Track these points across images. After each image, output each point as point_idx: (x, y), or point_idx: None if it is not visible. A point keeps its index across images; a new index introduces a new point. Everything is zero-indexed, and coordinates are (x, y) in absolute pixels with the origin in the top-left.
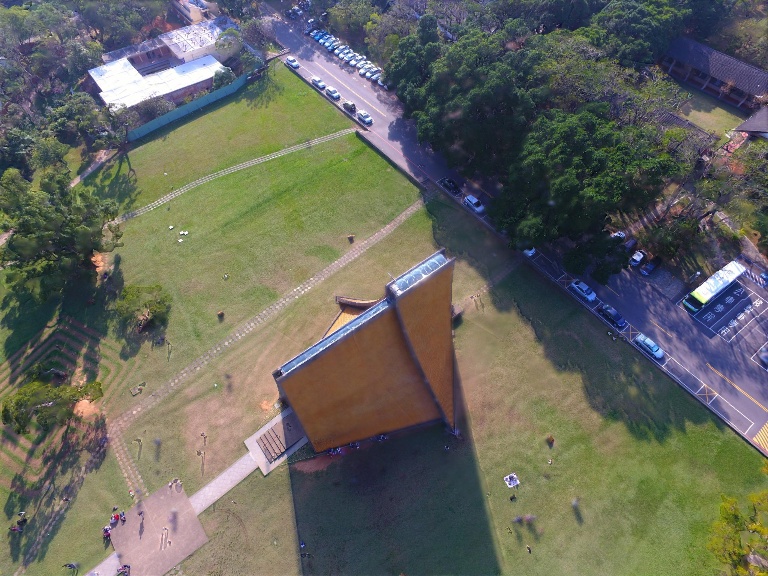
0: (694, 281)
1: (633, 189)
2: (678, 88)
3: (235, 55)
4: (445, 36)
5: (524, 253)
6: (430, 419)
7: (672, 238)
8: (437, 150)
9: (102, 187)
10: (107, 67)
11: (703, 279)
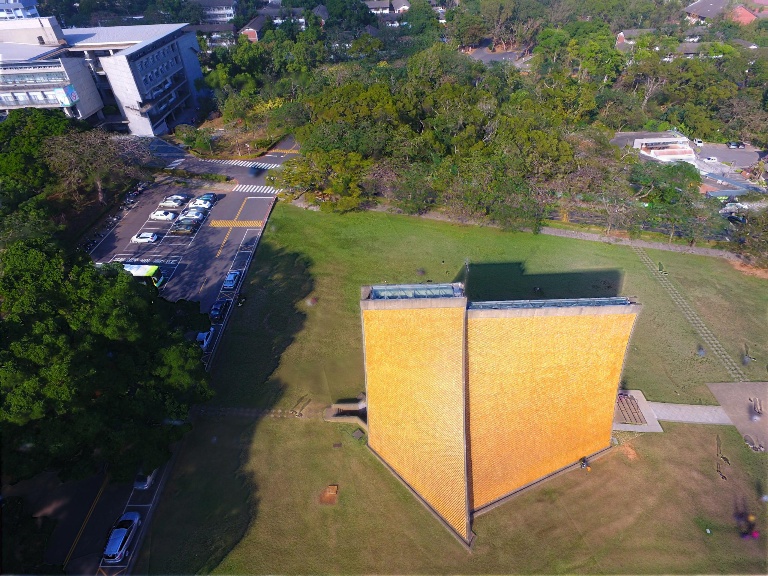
0: None
1: None
2: None
3: None
4: None
5: None
6: None
7: None
8: None
9: None
10: None
11: None
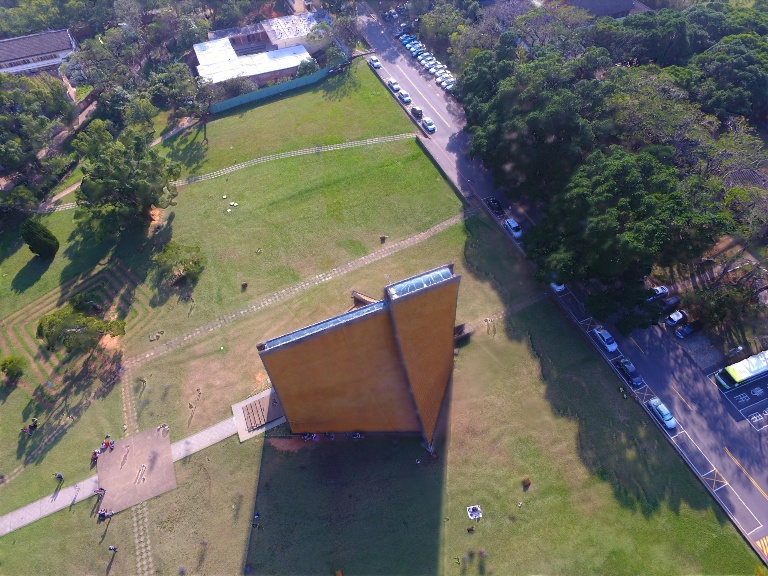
0: (735, 356)
1: (677, 242)
2: (762, 144)
3: (324, 48)
4: (529, 56)
5: (552, 287)
6: (409, 430)
7: (716, 304)
8: (488, 168)
9: (177, 150)
10: (210, 44)
11: (747, 356)
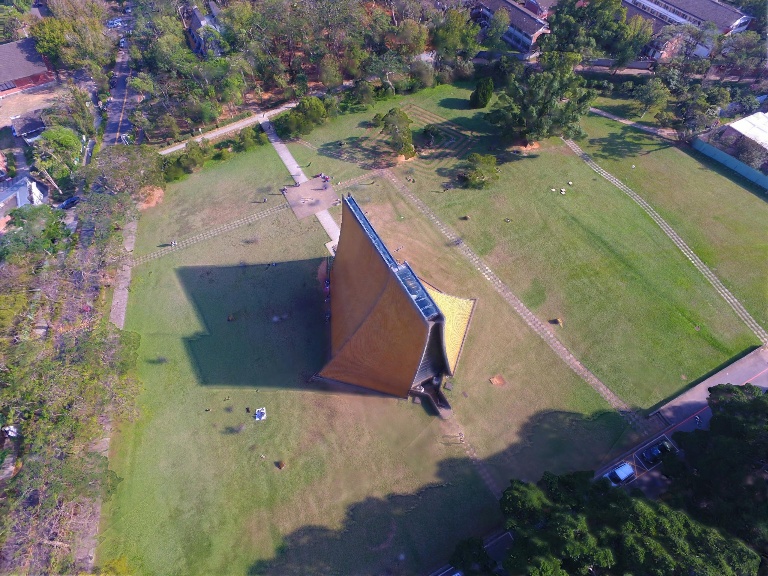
0: None
1: None
2: None
3: None
4: None
5: None
6: None
7: None
8: None
9: (621, 137)
10: None
11: None
